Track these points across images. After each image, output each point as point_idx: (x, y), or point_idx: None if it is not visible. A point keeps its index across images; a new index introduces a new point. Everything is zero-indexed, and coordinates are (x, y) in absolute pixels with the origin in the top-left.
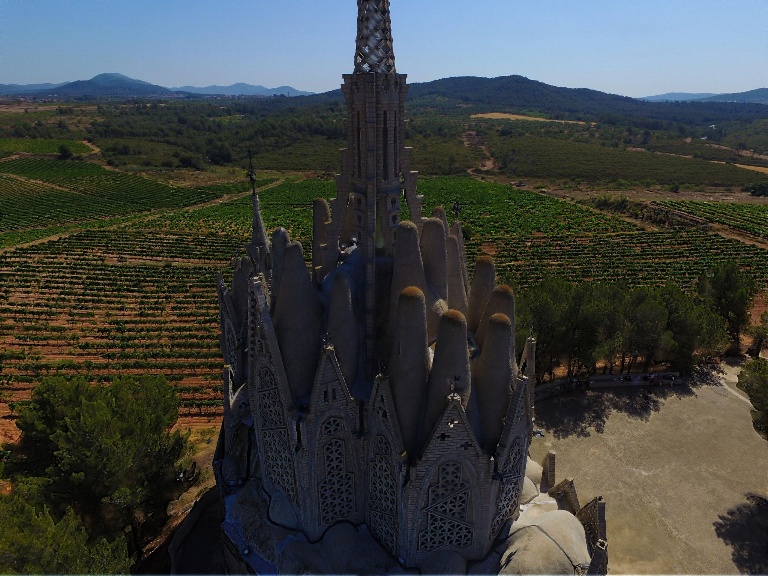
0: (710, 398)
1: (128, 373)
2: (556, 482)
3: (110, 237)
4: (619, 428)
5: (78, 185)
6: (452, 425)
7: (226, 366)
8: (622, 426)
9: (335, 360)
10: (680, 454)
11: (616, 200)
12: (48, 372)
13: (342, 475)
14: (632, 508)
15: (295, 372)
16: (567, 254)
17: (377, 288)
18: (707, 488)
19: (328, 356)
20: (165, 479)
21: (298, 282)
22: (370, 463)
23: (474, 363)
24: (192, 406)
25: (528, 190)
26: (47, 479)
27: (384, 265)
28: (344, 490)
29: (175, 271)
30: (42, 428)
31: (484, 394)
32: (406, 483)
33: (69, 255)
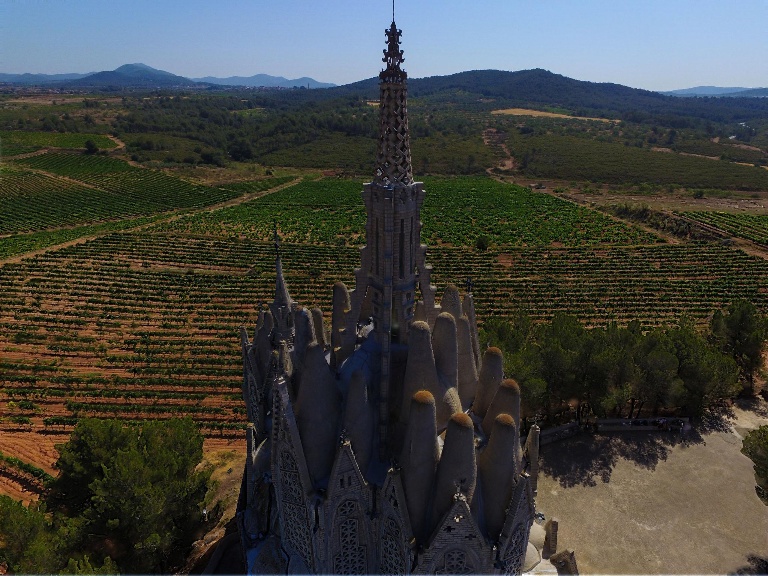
0: (718, 446)
1: (153, 389)
2: (560, 535)
3: (135, 241)
4: (625, 477)
5: (104, 182)
6: (458, 519)
7: (249, 425)
8: (628, 475)
9: (351, 454)
10: (684, 508)
11: (637, 208)
12: (78, 385)
13: (355, 548)
14: (633, 566)
15: (314, 458)
16: (584, 268)
17: (391, 376)
18: (709, 547)
19: (345, 451)
20: (191, 522)
21: (319, 378)
22: (381, 539)
23: (480, 454)
24: (213, 428)
25: (547, 194)
26: (84, 519)
27: (398, 353)
28: (357, 560)
29: (197, 279)
30: (80, 470)
31: (489, 486)
32: (414, 568)
33: (96, 260)
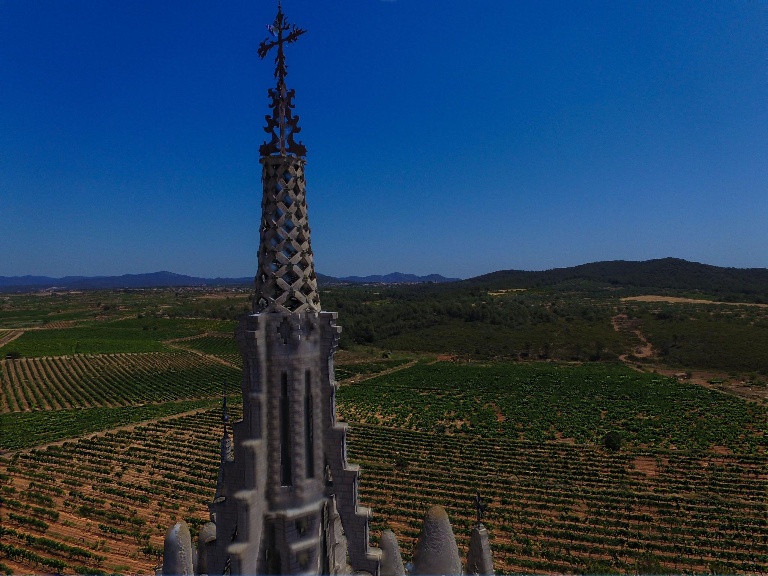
0: None
1: None
2: None
3: (237, 415)
4: None
5: (239, 360)
6: None
7: None
8: None
9: None
10: None
11: None
12: None
13: None
14: None
15: None
16: None
17: None
18: None
19: None
20: None
21: None
22: None
23: None
24: None
25: (699, 385)
26: None
27: None
28: None
29: None
30: None
31: None
32: None
33: (195, 432)
